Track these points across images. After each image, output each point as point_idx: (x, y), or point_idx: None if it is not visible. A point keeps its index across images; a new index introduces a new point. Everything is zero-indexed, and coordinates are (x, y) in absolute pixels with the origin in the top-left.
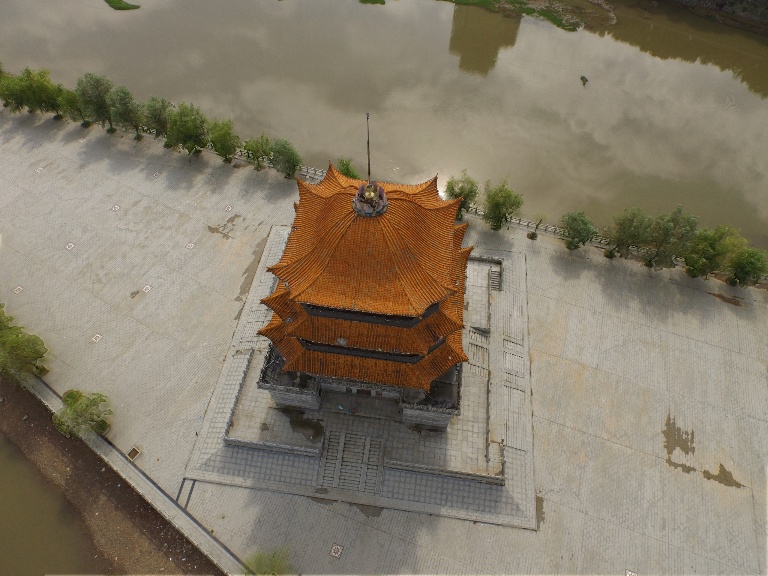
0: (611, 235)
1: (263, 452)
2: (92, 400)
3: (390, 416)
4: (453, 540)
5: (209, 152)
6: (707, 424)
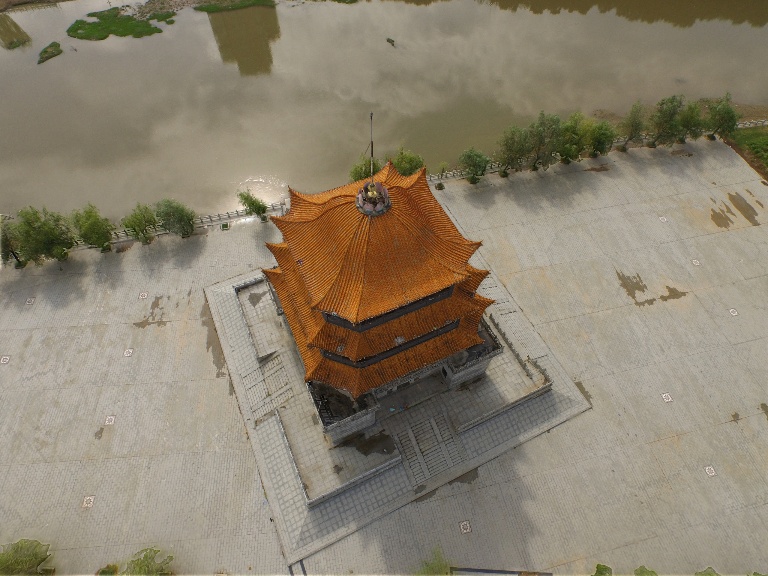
0: (501, 157)
1: (349, 492)
2: (146, 559)
3: (437, 391)
4: (543, 455)
5: (77, 250)
6: (642, 264)
